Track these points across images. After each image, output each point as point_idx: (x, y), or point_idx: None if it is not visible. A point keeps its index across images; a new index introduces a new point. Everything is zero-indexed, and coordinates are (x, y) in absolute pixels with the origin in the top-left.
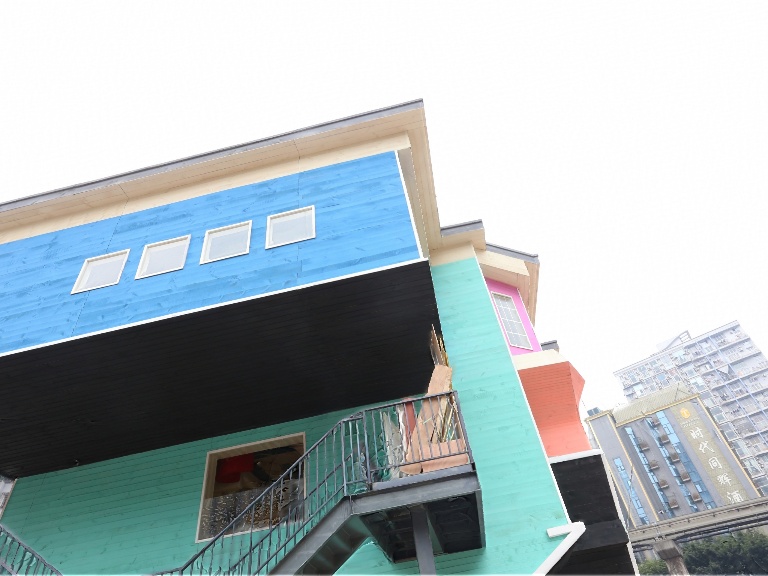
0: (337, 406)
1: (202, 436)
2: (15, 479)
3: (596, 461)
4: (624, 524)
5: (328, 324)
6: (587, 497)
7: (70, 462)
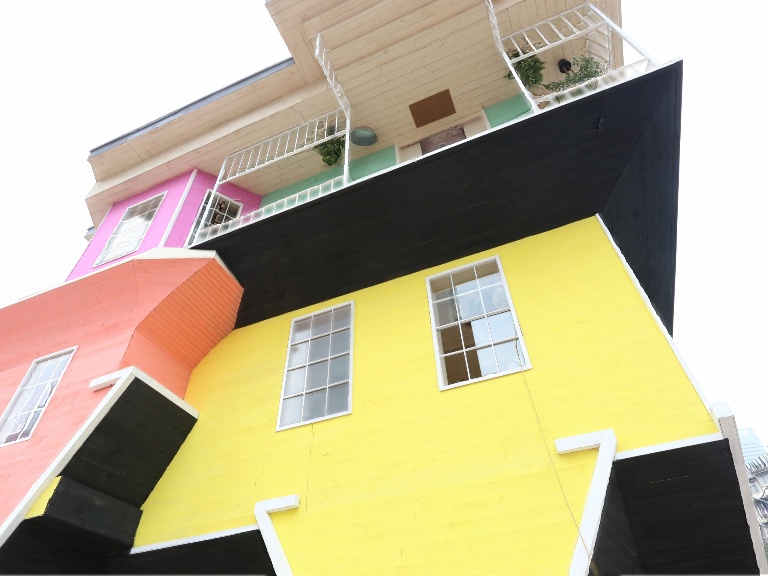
0: None
1: None
2: None
3: None
4: None
5: None
6: None
7: None
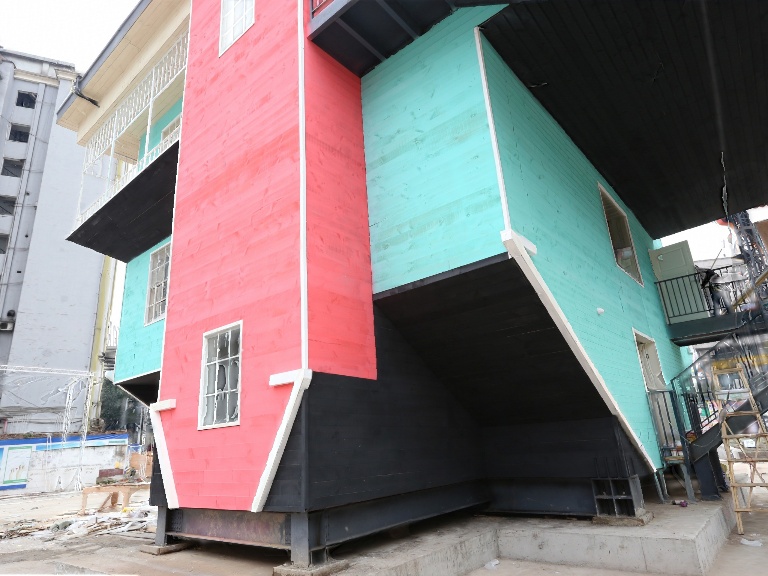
0: (640, 210)
1: (598, 161)
2: (478, 26)
3: None
4: None
5: None
6: None
7: (540, 78)
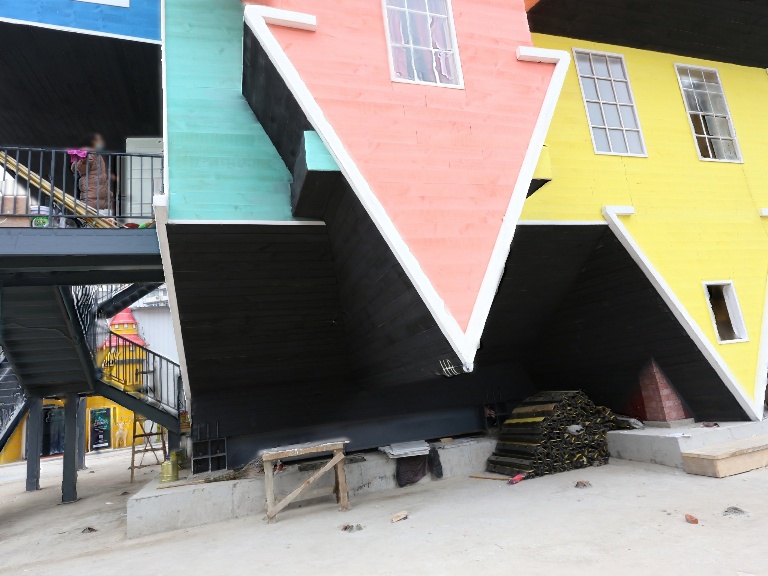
0: None
1: None
2: None
3: (250, 39)
4: (321, 134)
5: (2, 101)
6: (280, 114)
7: None
